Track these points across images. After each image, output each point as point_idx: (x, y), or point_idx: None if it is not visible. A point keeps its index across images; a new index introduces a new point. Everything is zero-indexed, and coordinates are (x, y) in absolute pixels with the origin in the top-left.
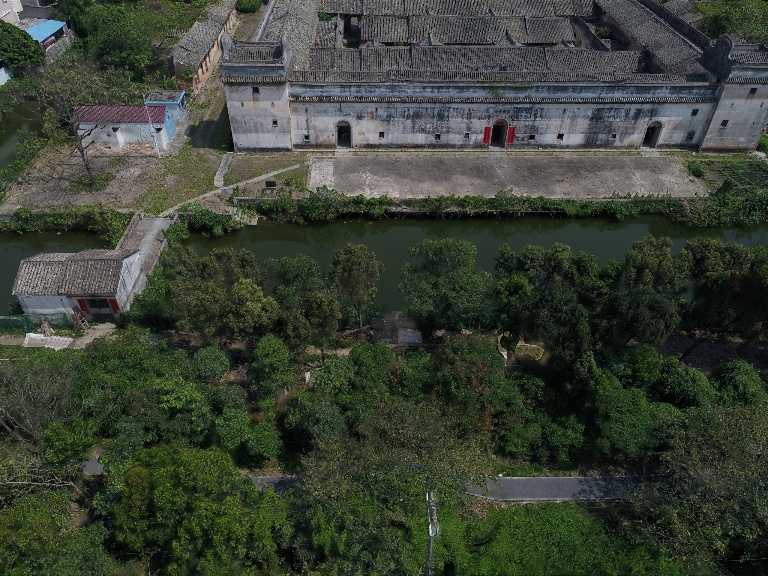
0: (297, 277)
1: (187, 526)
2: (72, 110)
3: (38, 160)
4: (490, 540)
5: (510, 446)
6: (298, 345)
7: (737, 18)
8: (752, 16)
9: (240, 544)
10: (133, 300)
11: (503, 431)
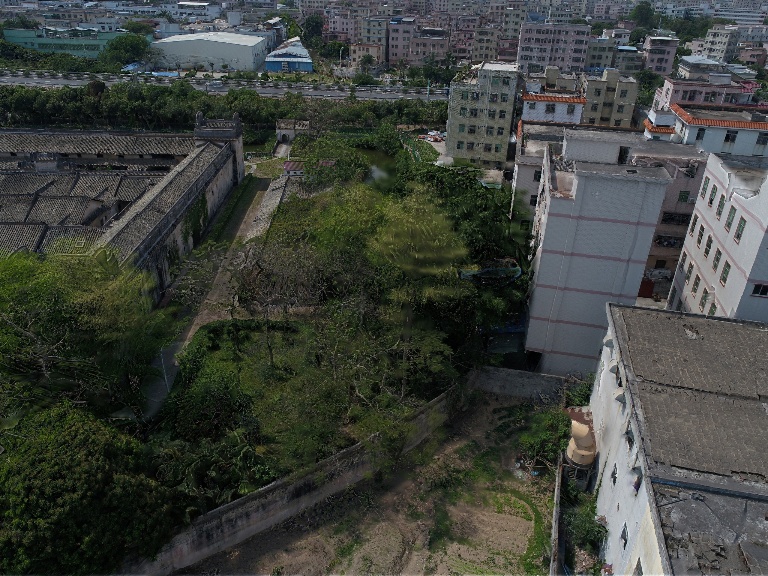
0: None
1: None
2: None
3: None
4: None
5: None
6: None
7: None
8: None
9: None
10: None
11: None
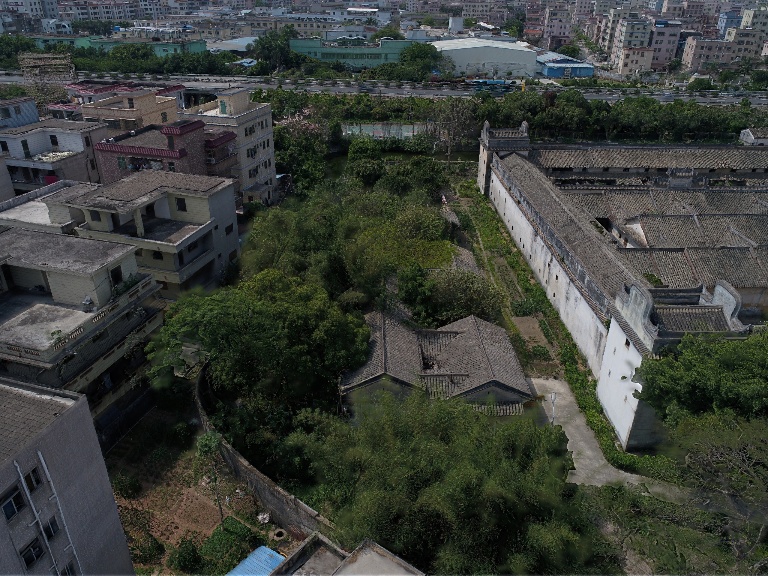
0: None
1: None
2: None
3: None
4: None
5: None
6: None
7: None
8: None
9: None
10: None
11: None
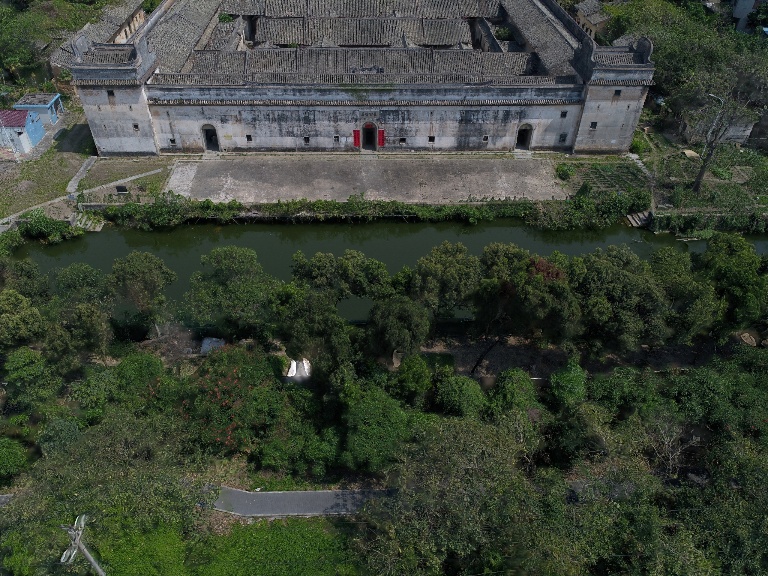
0: (70, 287)
1: None
2: None
3: None
4: (211, 559)
5: (268, 460)
6: (60, 358)
7: (636, 19)
8: (651, 17)
9: None
10: None
11: (263, 444)
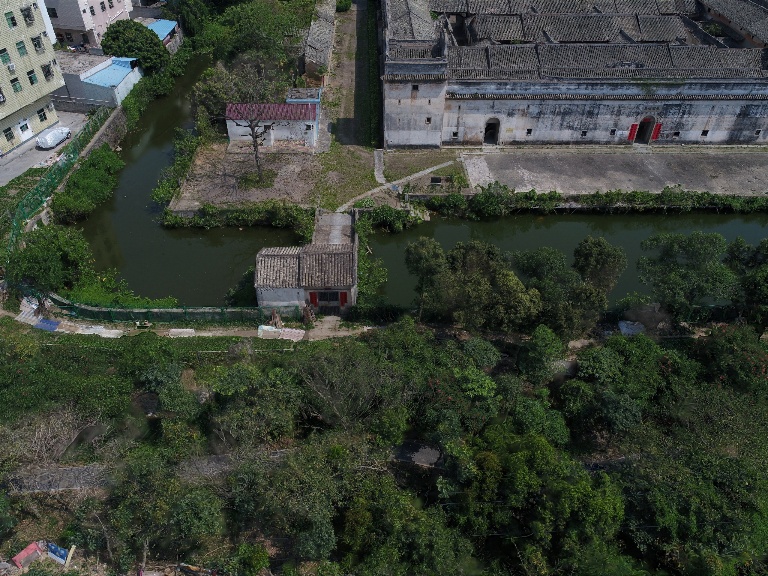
0: (551, 270)
1: (552, 508)
2: (221, 108)
3: (197, 157)
4: None
5: None
6: None
7: None
8: None
9: (606, 525)
10: (358, 293)
11: None
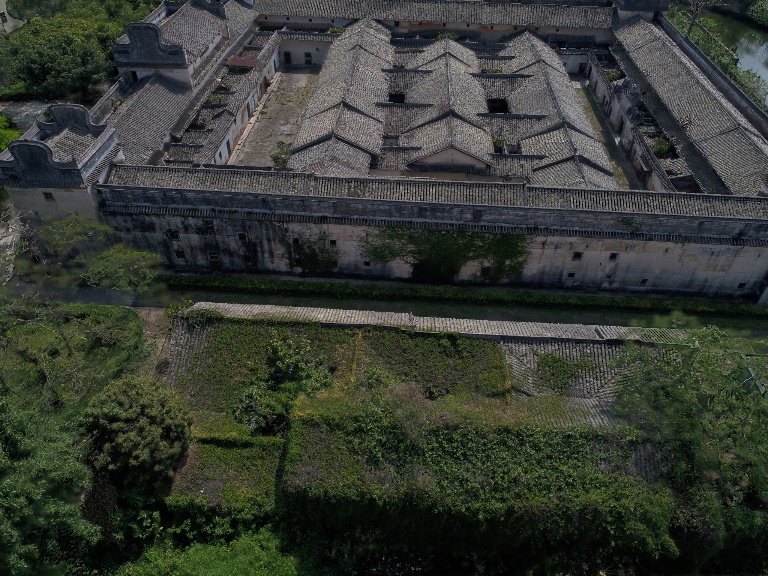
0: None
1: None
2: None
3: None
4: None
5: None
6: None
7: None
8: None
9: None
10: None
11: None
